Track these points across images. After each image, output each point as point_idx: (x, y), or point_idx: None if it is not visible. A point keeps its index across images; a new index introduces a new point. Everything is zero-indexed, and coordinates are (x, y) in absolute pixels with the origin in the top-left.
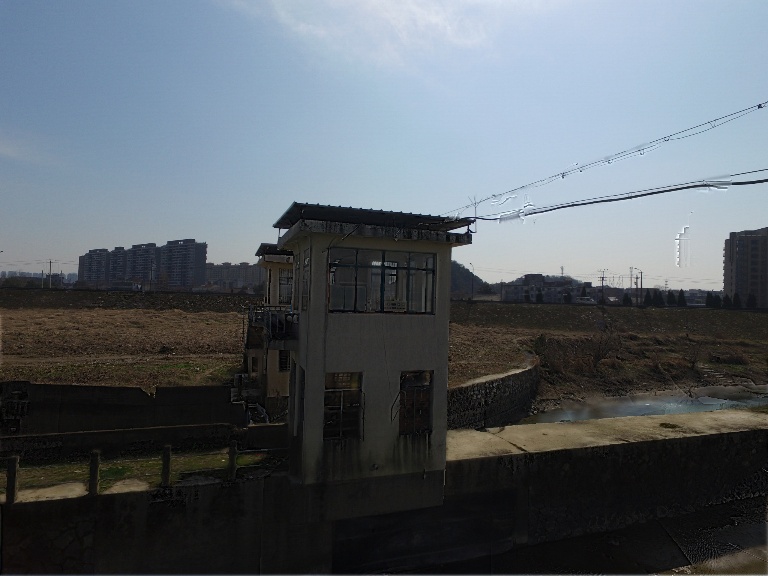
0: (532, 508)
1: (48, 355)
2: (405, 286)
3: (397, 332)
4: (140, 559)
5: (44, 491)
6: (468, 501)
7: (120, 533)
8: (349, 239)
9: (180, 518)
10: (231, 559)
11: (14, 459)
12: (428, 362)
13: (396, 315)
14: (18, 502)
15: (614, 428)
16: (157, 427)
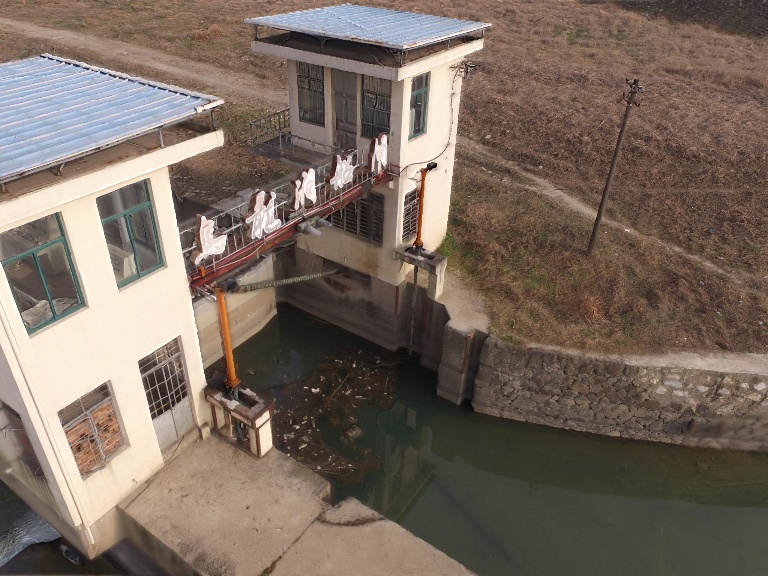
0: None
1: (283, 84)
2: (151, 222)
3: None
4: None
5: None
6: None
7: None
8: None
9: None
10: None
11: None
12: (9, 399)
13: None
14: None
15: None
16: None
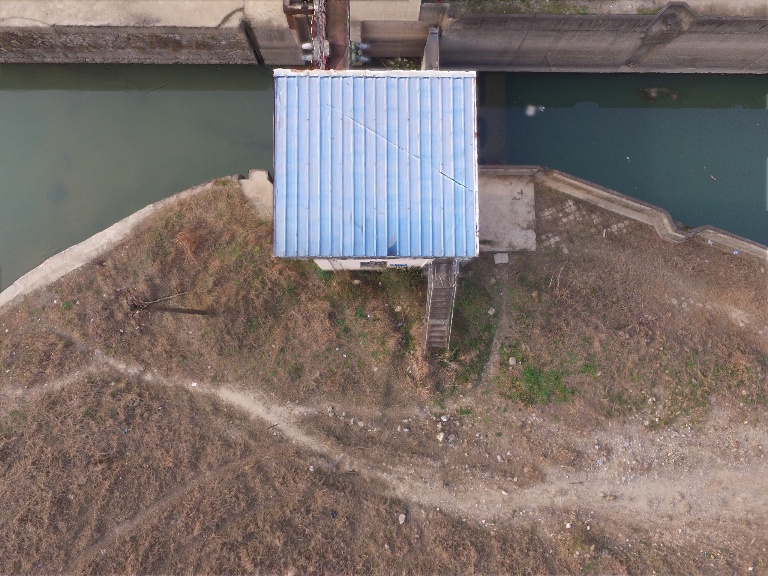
0: None
1: None
2: None
3: None
4: None
5: None
6: None
7: None
8: None
9: None
10: None
11: None
12: None
13: None
14: None
15: None
16: (514, 15)
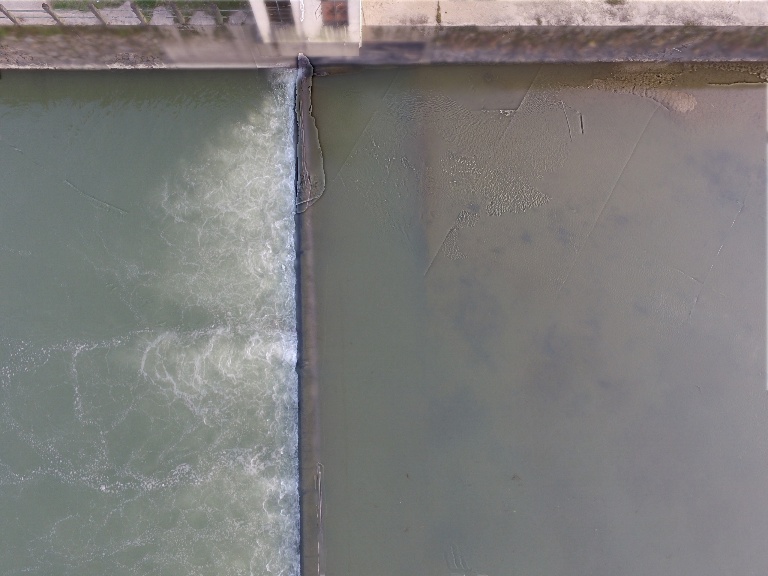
0: (437, 51)
1: None
2: None
3: None
4: (186, 49)
5: (117, 12)
6: (386, 45)
7: None
8: None
9: (199, 37)
10: (236, 54)
11: (91, 7)
12: None
13: None
14: (108, 24)
15: None
16: None
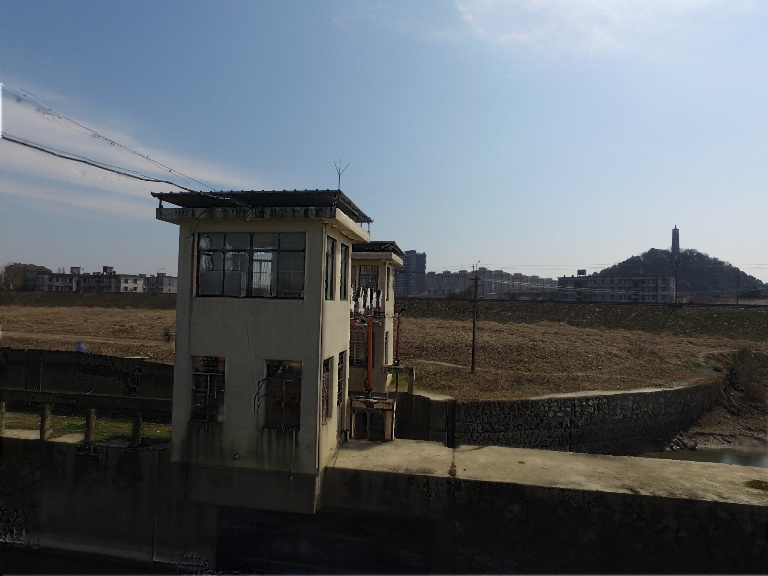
0: (460, 550)
1: None
2: (343, 273)
3: (261, 318)
4: (69, 499)
5: (26, 432)
6: (368, 520)
7: (57, 474)
8: (212, 224)
9: (96, 472)
10: (132, 518)
11: None
12: (295, 352)
13: (260, 300)
14: (1, 436)
15: (649, 472)
16: None
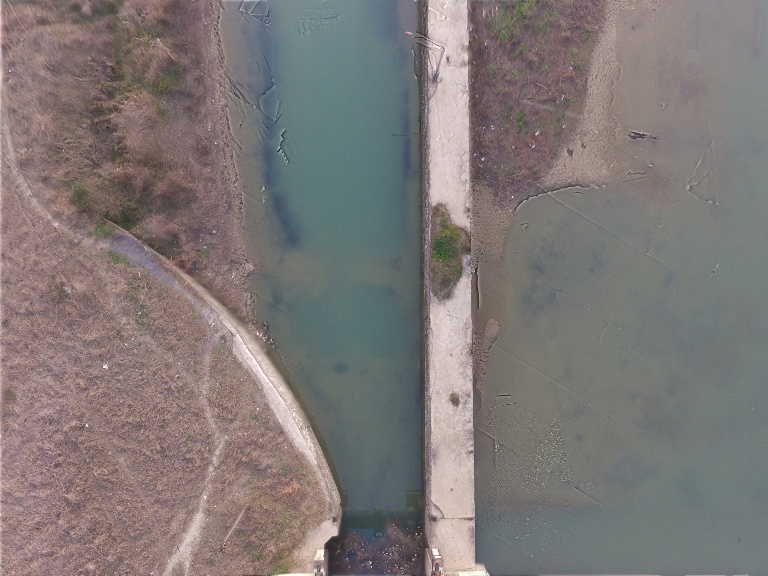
0: None
1: None
2: None
3: None
4: None
5: None
6: None
7: None
8: None
9: None
10: None
11: None
12: None
13: None
14: None
15: (451, 439)
16: None
